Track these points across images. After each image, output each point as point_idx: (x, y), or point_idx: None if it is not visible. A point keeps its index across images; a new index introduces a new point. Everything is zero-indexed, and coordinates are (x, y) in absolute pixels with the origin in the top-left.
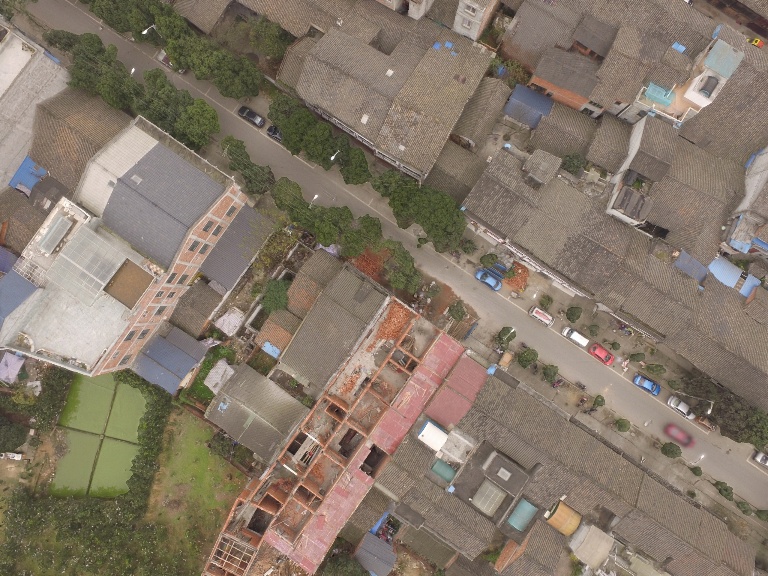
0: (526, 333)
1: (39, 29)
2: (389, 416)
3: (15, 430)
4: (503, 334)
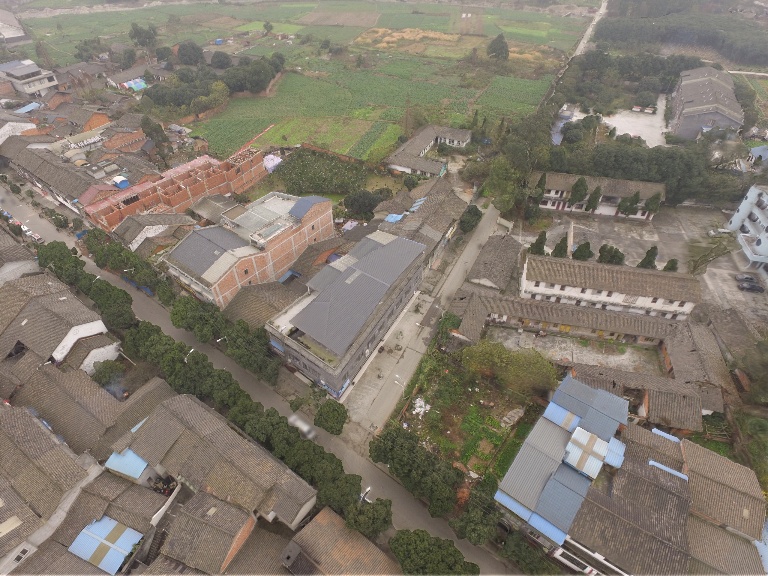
0: (53, 236)
1: (314, 412)
2: (140, 190)
3: (345, 202)
4: (62, 221)
